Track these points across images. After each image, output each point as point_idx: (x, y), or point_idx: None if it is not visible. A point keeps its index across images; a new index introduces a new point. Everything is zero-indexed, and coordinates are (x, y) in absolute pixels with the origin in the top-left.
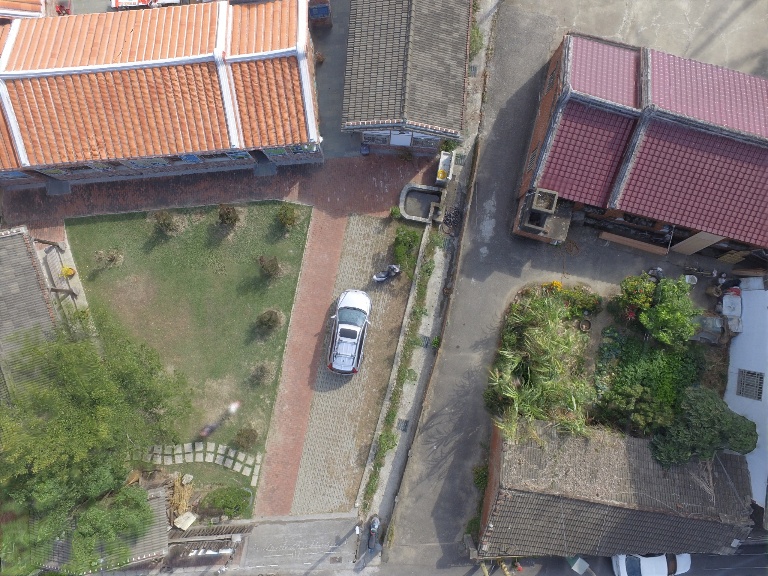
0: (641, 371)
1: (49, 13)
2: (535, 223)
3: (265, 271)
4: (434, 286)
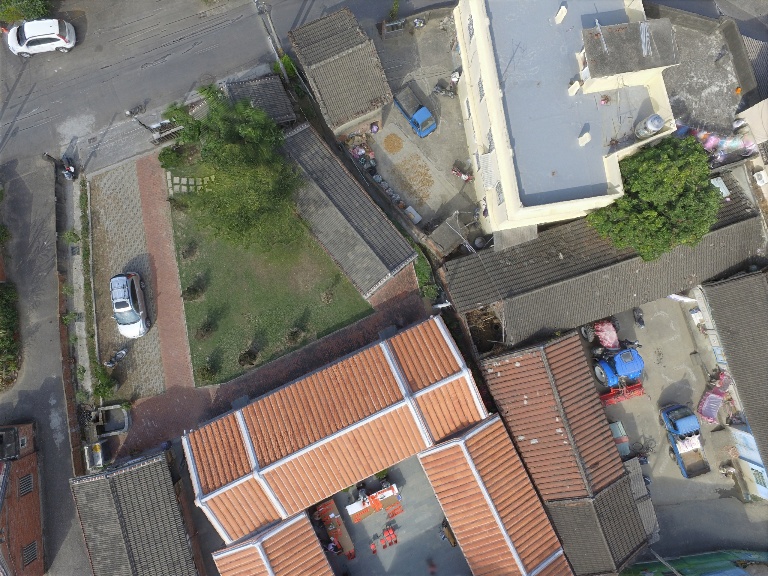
0: None
1: None
2: None
3: (204, 328)
4: (84, 361)
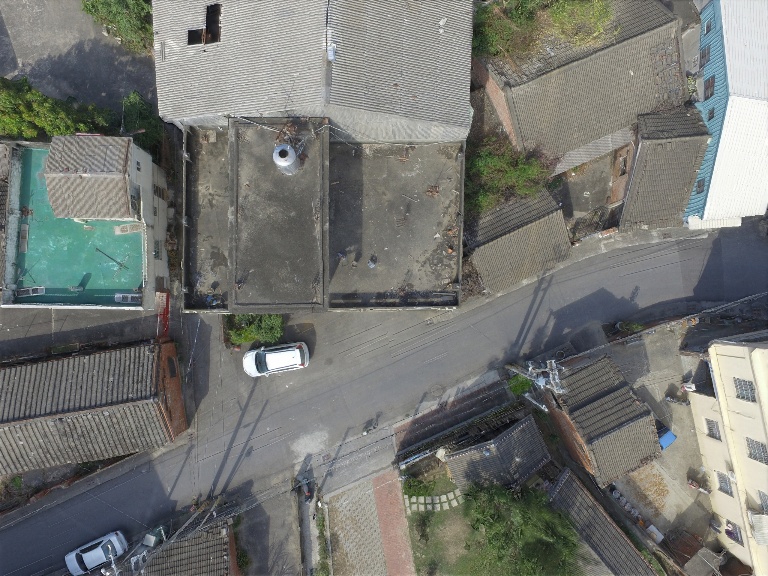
0: None
1: None
2: None
3: None
4: None
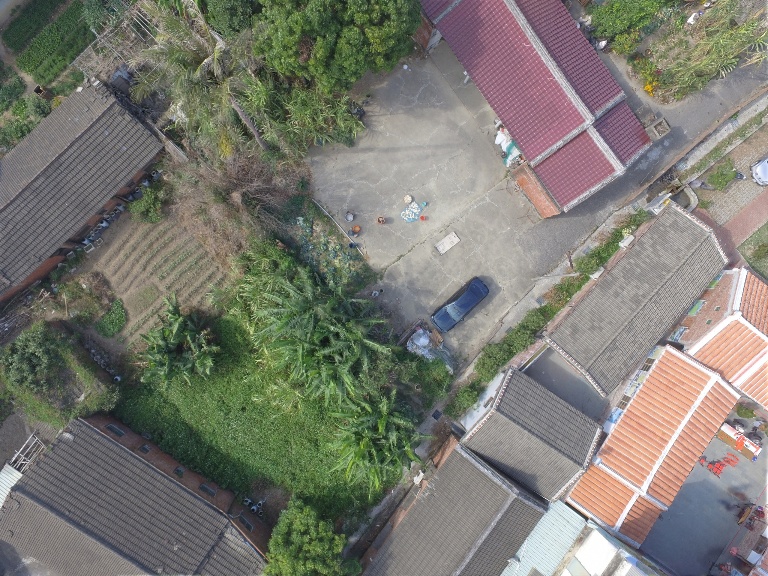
0: None
1: None
2: None
3: None
4: (706, 148)
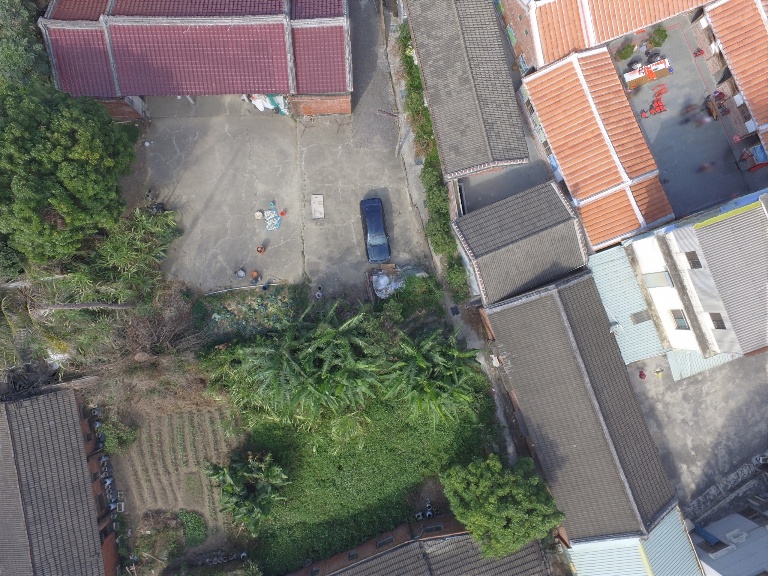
0: None
1: (706, 41)
2: None
3: None
4: None
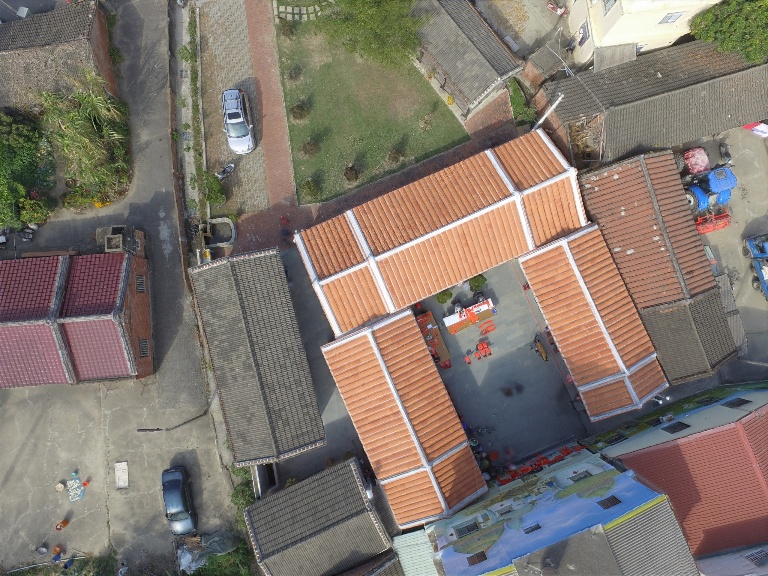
0: (18, 162)
1: None
2: (122, 234)
3: None
4: None
